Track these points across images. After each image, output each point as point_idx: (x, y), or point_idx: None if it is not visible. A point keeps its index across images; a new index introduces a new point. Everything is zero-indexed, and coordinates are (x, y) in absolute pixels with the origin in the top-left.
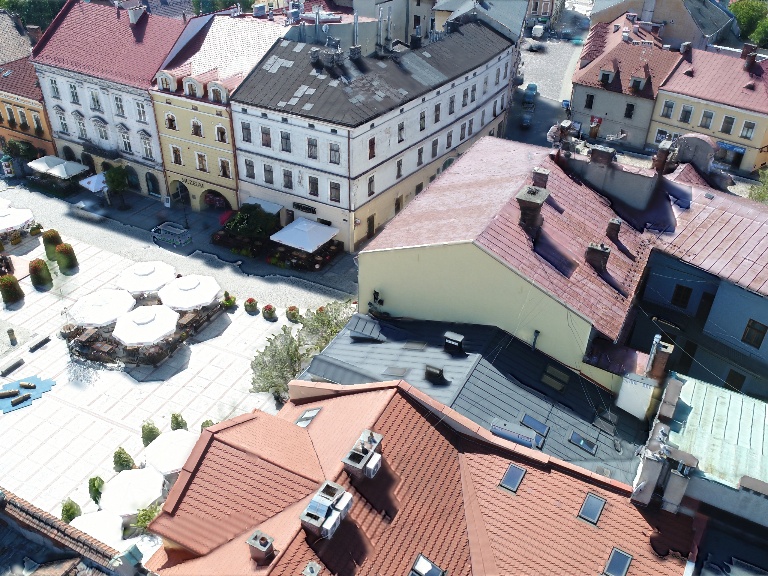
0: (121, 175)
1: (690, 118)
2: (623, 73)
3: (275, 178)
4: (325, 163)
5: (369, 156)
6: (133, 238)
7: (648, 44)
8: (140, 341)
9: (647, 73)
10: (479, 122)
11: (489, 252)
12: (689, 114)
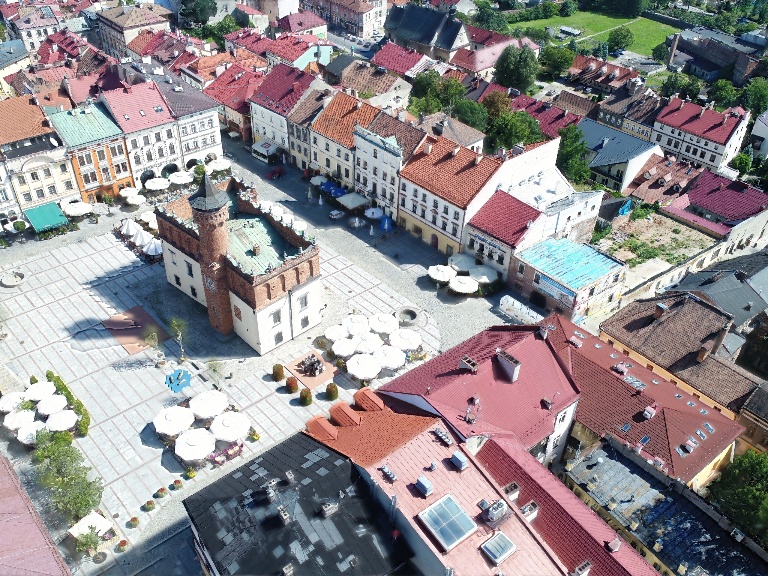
0: None
1: None
2: None
3: None
4: None
5: None
6: None
7: None
8: None
9: None
10: None
11: None
12: None
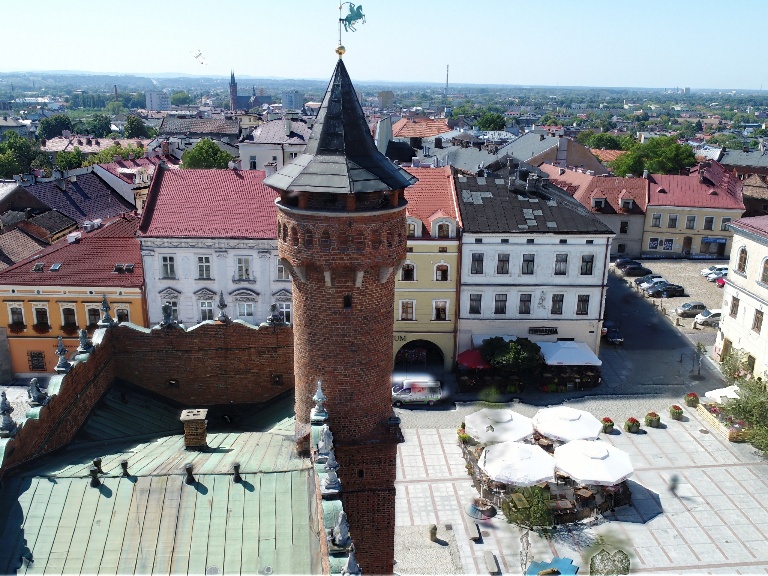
0: None
1: (677, 224)
2: (609, 199)
3: (509, 306)
4: (575, 277)
5: None
6: None
7: None
8: (623, 475)
9: (631, 195)
10: None
11: None
12: (675, 221)
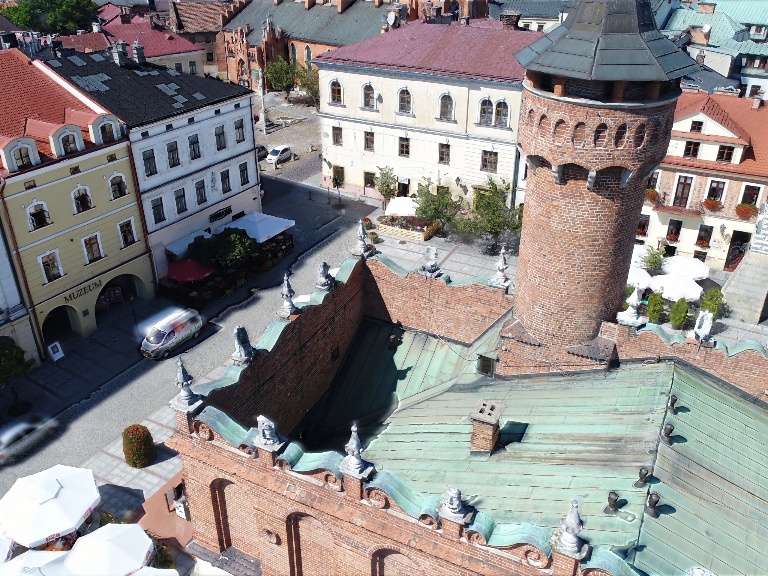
0: (16, 347)
1: None
2: None
3: (189, 201)
4: (233, 147)
5: None
6: (143, 381)
7: None
8: None
9: None
10: None
11: None
12: None
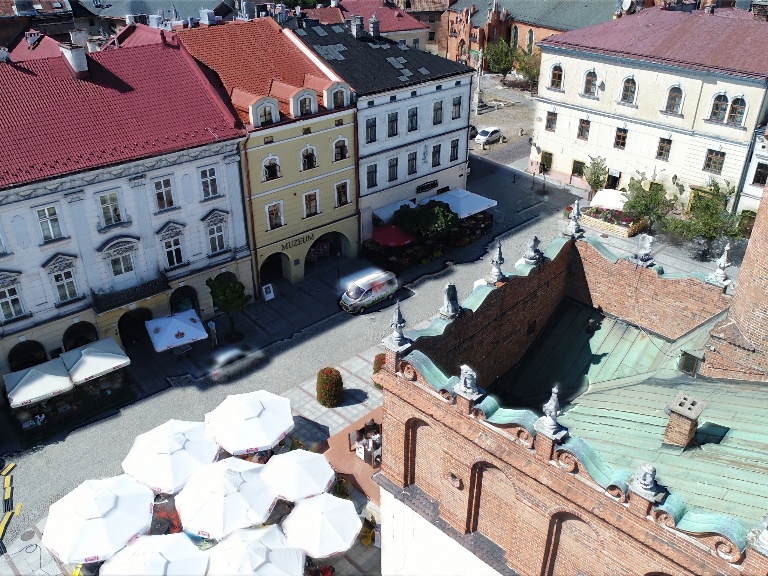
0: (239, 282)
1: None
2: None
3: (400, 170)
4: (448, 123)
5: None
6: (339, 331)
7: None
8: None
9: None
10: None
11: None
12: None
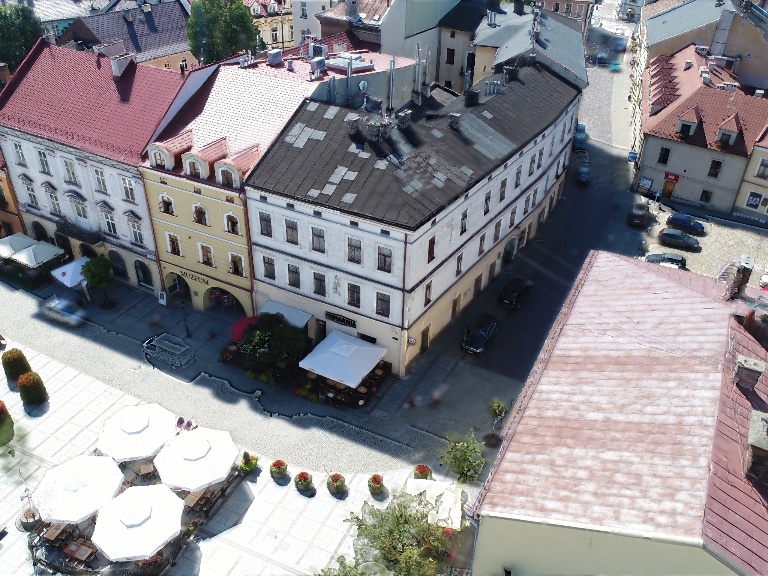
0: (103, 268)
1: None
2: (707, 124)
3: (302, 281)
4: (371, 269)
5: (428, 259)
6: (119, 353)
7: (731, 86)
8: (130, 555)
9: (738, 125)
10: (543, 189)
11: (733, 565)
12: None
